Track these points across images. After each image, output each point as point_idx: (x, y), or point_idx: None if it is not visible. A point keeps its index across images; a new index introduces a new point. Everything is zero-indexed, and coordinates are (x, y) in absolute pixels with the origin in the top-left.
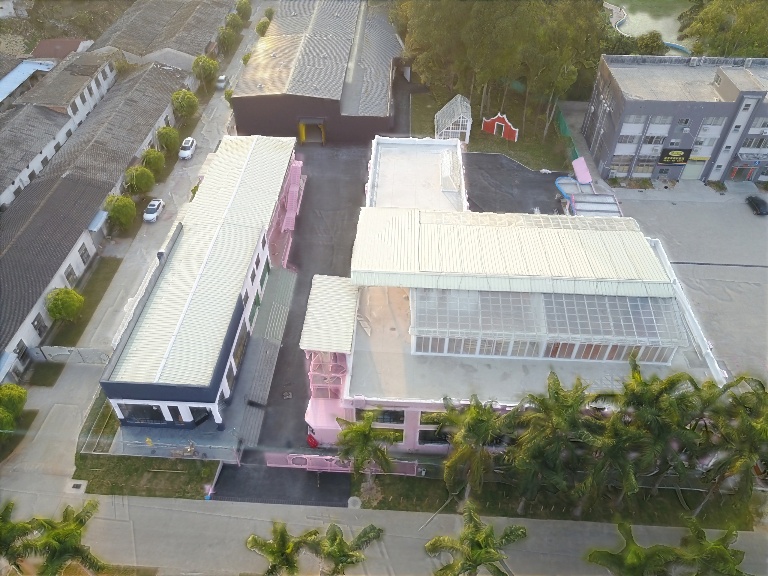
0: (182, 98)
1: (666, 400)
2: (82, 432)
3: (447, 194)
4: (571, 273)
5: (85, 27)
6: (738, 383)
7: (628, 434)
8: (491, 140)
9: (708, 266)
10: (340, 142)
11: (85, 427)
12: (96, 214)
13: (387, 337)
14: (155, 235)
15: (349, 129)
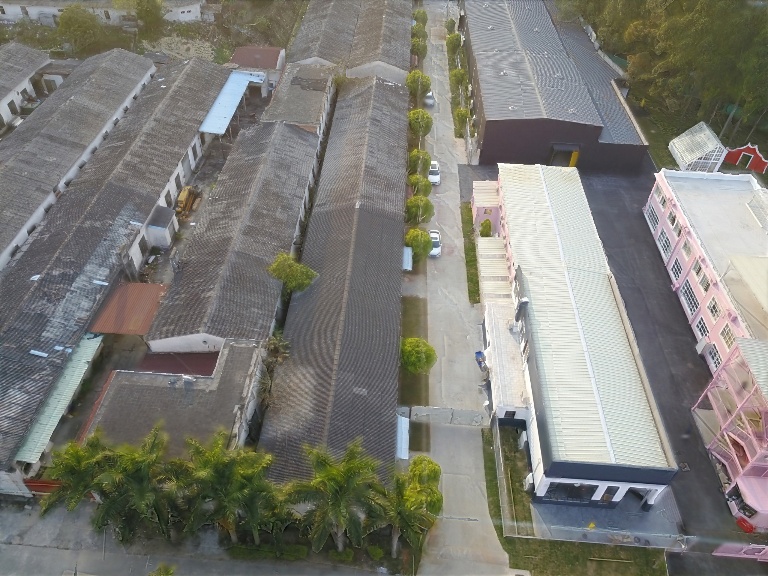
0: (421, 118)
1: None
2: (491, 509)
3: None
4: None
5: (266, 34)
6: None
7: None
8: (737, 171)
9: None
10: (588, 170)
11: (491, 503)
12: (403, 250)
13: None
14: (447, 272)
15: (602, 157)
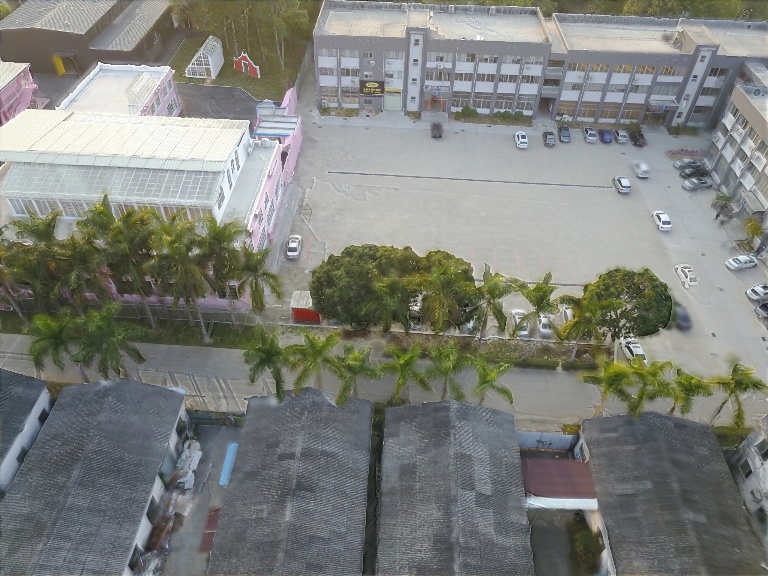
0: None
1: (115, 223)
2: None
3: (131, 107)
4: (151, 154)
5: None
6: (179, 214)
7: (79, 246)
8: (238, 77)
9: (364, 175)
10: None
11: None
12: None
13: (2, 204)
14: None
15: None
